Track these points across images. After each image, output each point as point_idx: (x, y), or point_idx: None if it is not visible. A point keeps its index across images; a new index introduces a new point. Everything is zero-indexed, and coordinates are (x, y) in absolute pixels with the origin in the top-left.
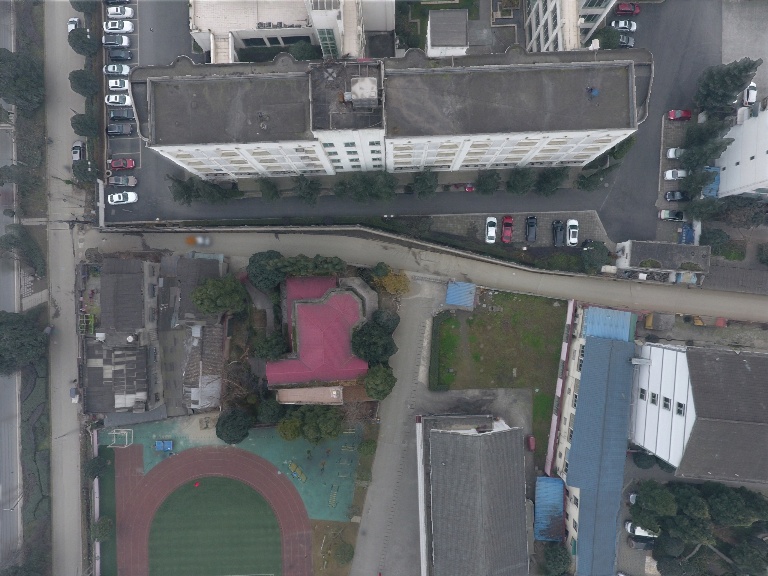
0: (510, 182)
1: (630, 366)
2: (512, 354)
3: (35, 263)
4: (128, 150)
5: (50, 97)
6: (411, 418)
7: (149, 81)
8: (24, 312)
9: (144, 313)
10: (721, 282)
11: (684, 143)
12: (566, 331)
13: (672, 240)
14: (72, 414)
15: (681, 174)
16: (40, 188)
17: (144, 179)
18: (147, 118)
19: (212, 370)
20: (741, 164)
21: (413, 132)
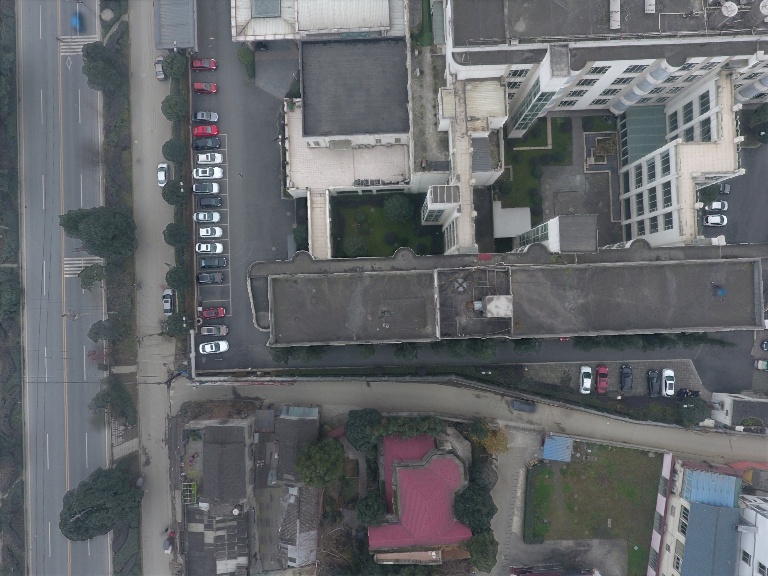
0: (611, 341)
1: (735, 532)
2: (607, 505)
3: (126, 413)
4: (218, 297)
5: (139, 243)
6: (505, 569)
7: (270, 279)
8: (115, 461)
9: (245, 479)
10: None
11: None
12: (663, 484)
13: None
14: (164, 563)
15: None
16: (130, 336)
17: (235, 327)
18: (263, 308)
19: (308, 527)
20: None
21: (535, 327)
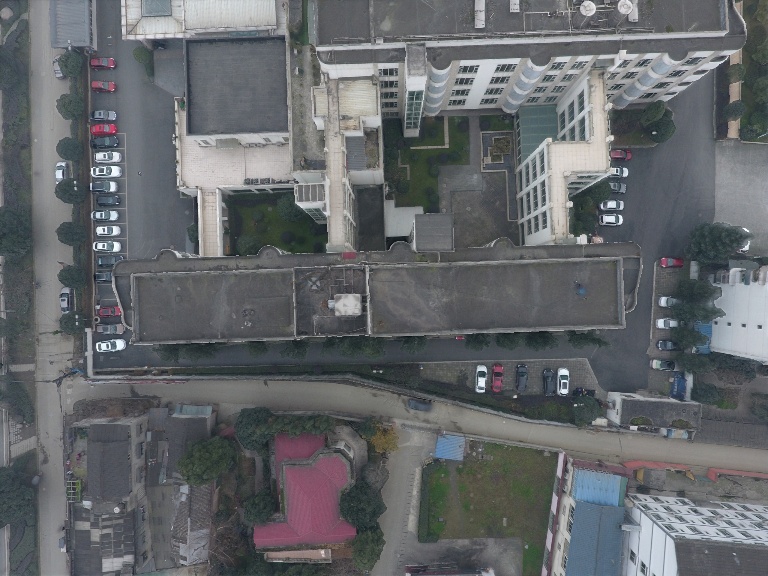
0: (500, 340)
1: (620, 531)
2: (502, 503)
3: (23, 411)
4: None
5: (38, 241)
6: (401, 568)
7: (133, 277)
8: (13, 459)
9: (131, 477)
10: (713, 436)
11: (676, 291)
12: (556, 483)
13: (664, 389)
14: (61, 561)
15: (673, 324)
16: (28, 334)
17: None
18: (131, 306)
19: (200, 525)
20: (733, 326)
21: (399, 326)
